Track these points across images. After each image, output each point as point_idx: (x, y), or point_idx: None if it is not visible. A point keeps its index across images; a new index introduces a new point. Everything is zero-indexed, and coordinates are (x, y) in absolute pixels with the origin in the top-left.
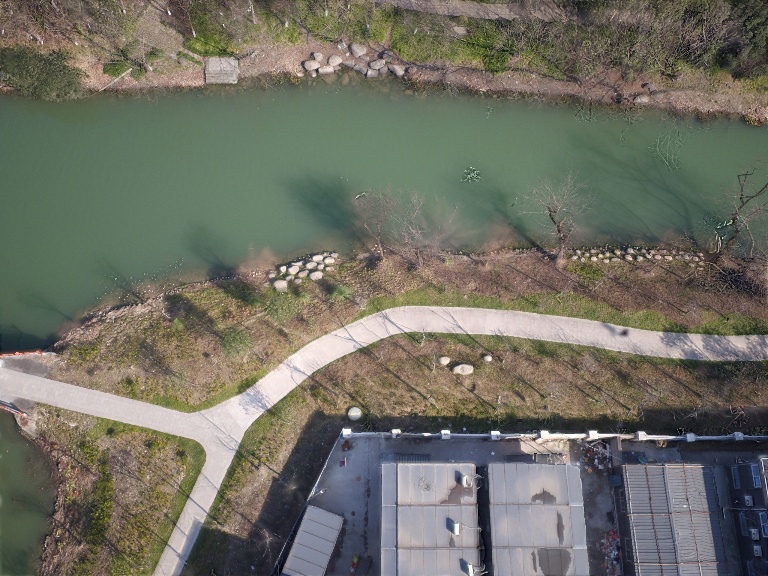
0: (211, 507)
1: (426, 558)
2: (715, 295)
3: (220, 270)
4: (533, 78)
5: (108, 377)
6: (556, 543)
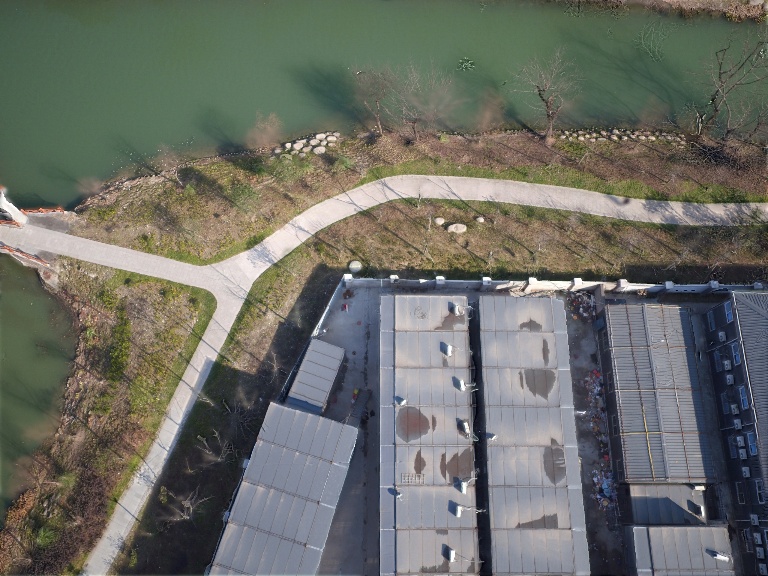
0: (222, 348)
1: (421, 376)
2: (695, 168)
3: (229, 147)
4: None
5: (125, 234)
6: (542, 364)
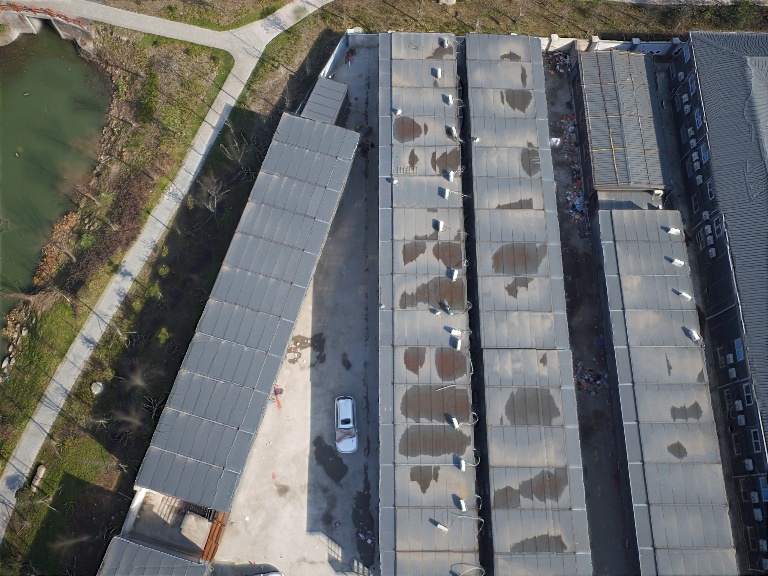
0: (239, 96)
1: (415, 93)
2: None
3: None
4: None
5: (152, 6)
6: (520, 86)
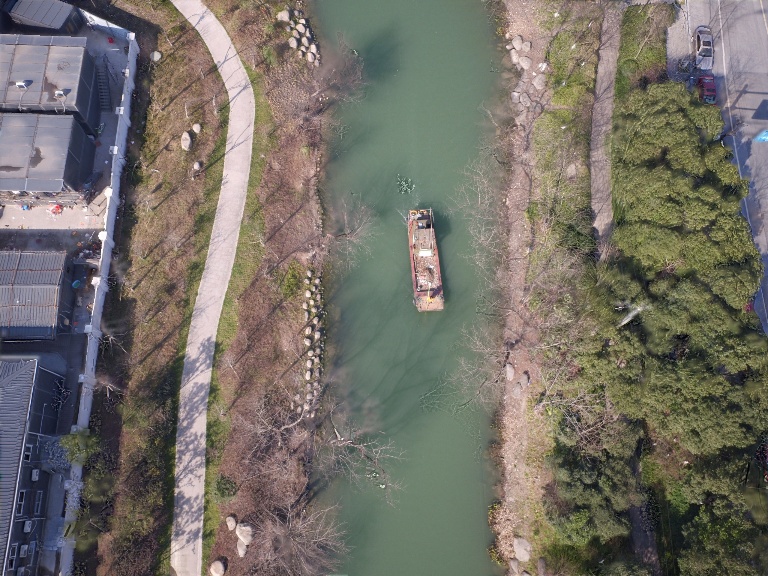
0: None
1: (4, 64)
2: None
3: None
4: (526, 252)
5: None
6: None
